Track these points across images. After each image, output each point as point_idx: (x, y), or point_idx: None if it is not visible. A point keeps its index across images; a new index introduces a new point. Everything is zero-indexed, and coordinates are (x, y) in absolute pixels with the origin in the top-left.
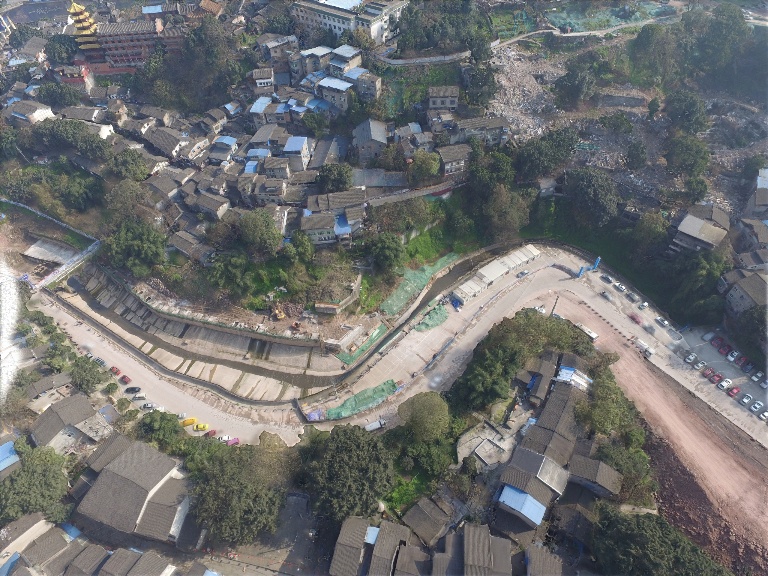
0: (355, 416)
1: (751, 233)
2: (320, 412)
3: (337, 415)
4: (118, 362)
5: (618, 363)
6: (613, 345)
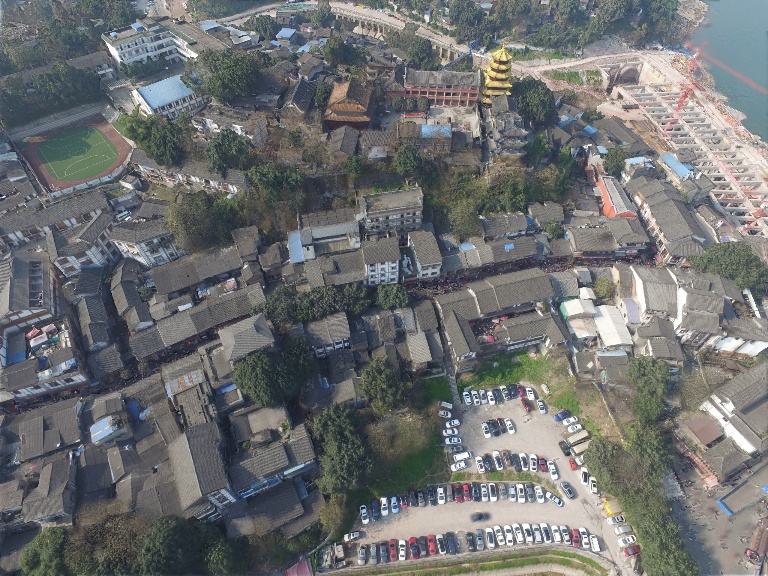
0: (298, 5)
1: (68, 2)
2: (311, 7)
3: (305, 5)
4: (403, 24)
5: (183, 1)
6: (178, 6)
